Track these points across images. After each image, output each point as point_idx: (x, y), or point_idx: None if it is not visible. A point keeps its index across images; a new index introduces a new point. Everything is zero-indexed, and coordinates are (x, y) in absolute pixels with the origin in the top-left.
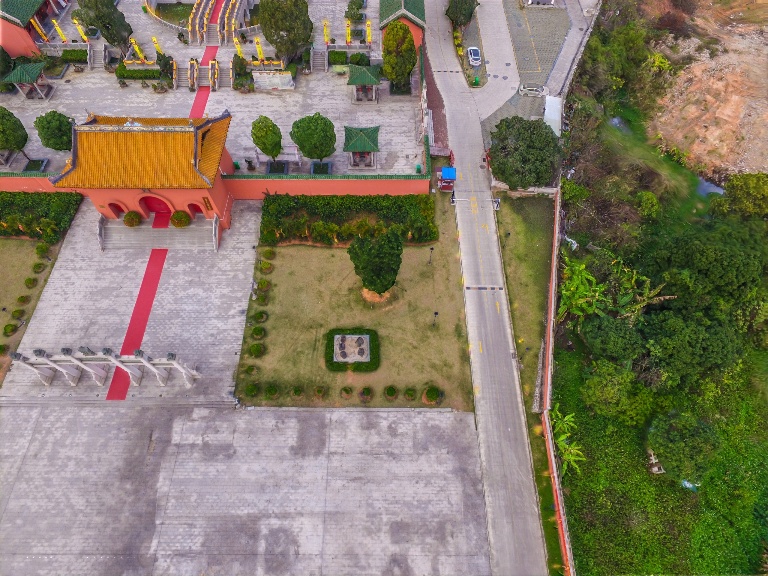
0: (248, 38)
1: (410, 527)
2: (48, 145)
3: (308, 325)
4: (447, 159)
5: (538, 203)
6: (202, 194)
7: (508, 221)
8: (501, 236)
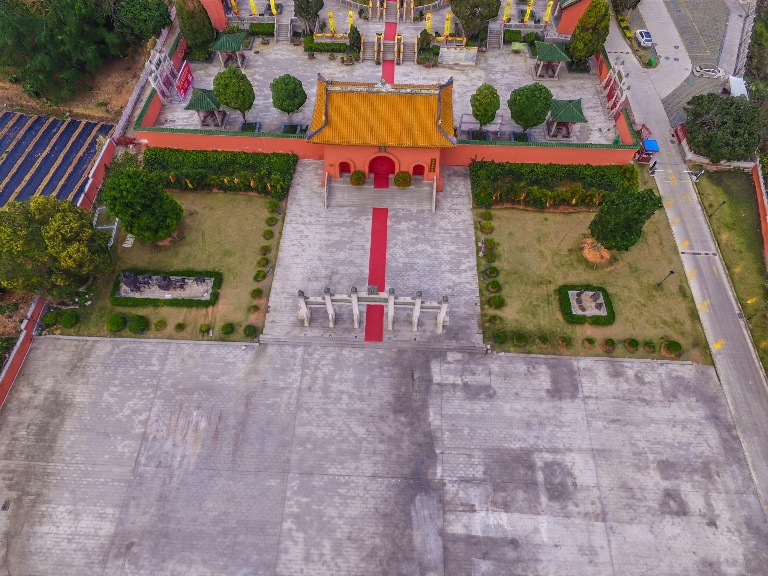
0: (423, 16)
1: (676, 466)
2: (281, 106)
3: (538, 281)
4: (637, 133)
5: (736, 176)
6: (433, 155)
7: (709, 192)
8: (705, 206)
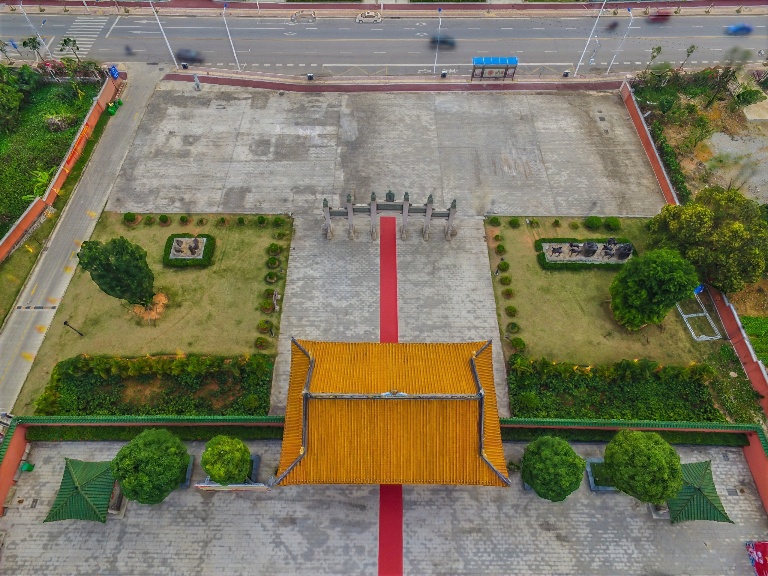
0: None
1: (176, 156)
2: None
3: (227, 272)
4: None
5: None
6: None
7: None
8: None
